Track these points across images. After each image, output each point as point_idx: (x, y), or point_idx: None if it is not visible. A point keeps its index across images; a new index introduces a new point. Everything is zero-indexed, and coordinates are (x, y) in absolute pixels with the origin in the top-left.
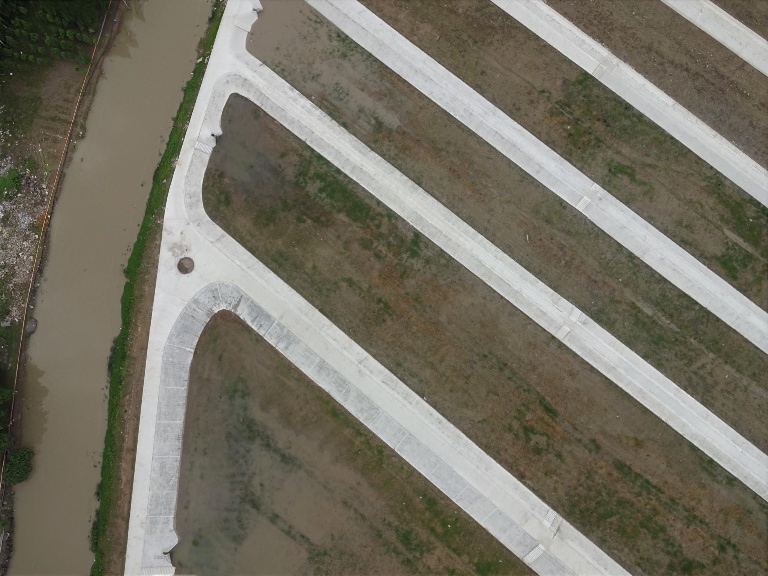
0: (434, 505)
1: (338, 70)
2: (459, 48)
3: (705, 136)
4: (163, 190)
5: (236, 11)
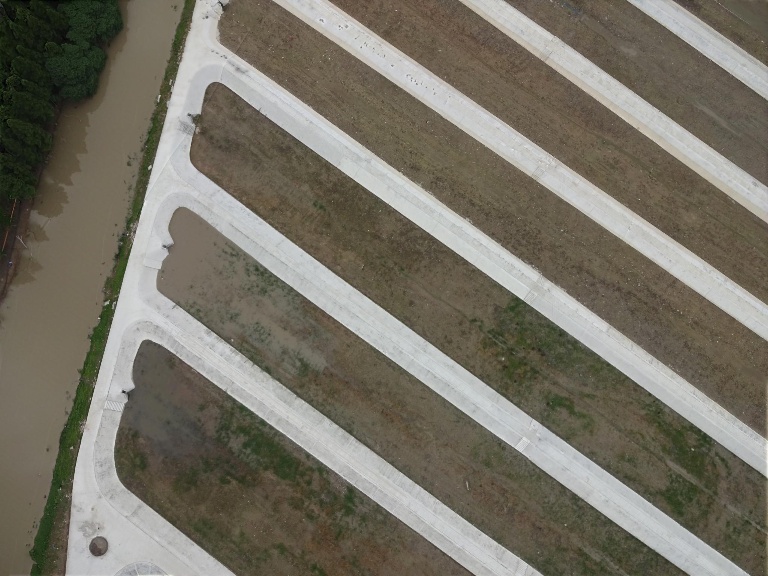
0: None
1: (258, 308)
2: (385, 277)
3: (641, 363)
4: (70, 458)
5: (144, 249)
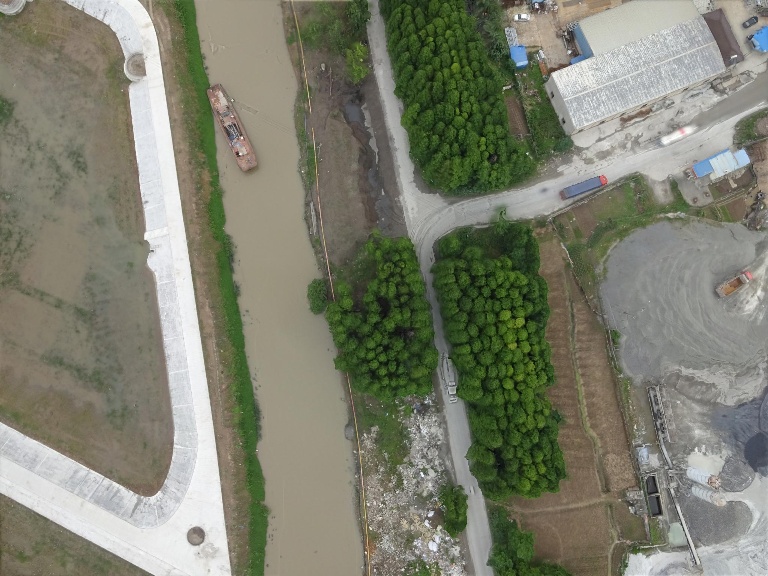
0: None
1: None
2: None
3: None
4: None
5: None
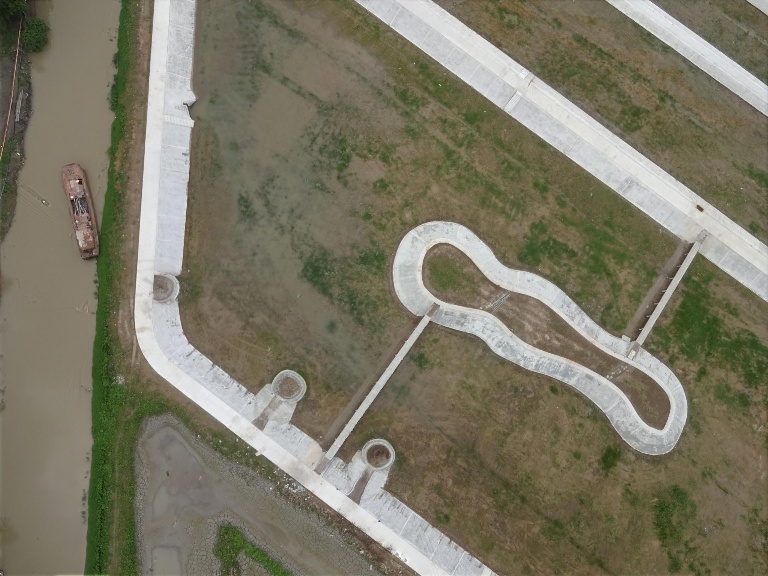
0: (426, 69)
1: None
2: None
3: None
4: None
5: None
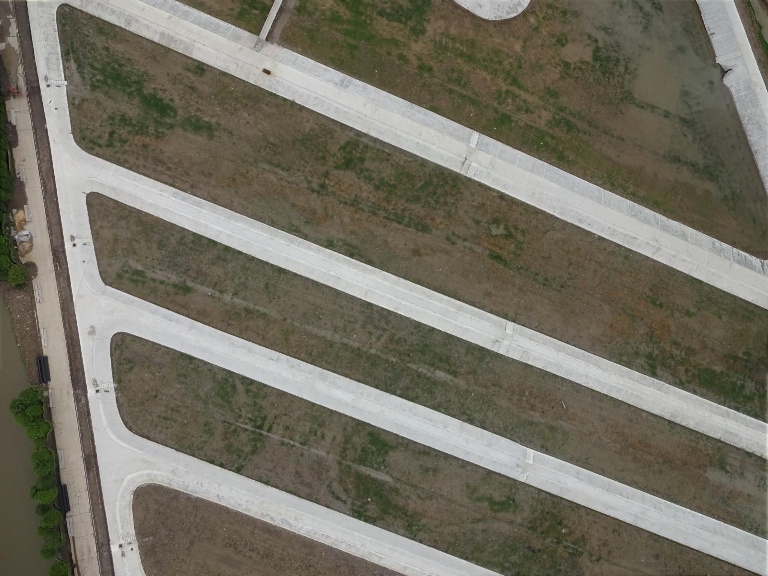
0: (559, 156)
1: None
2: (686, 575)
3: (440, 572)
4: None
5: None
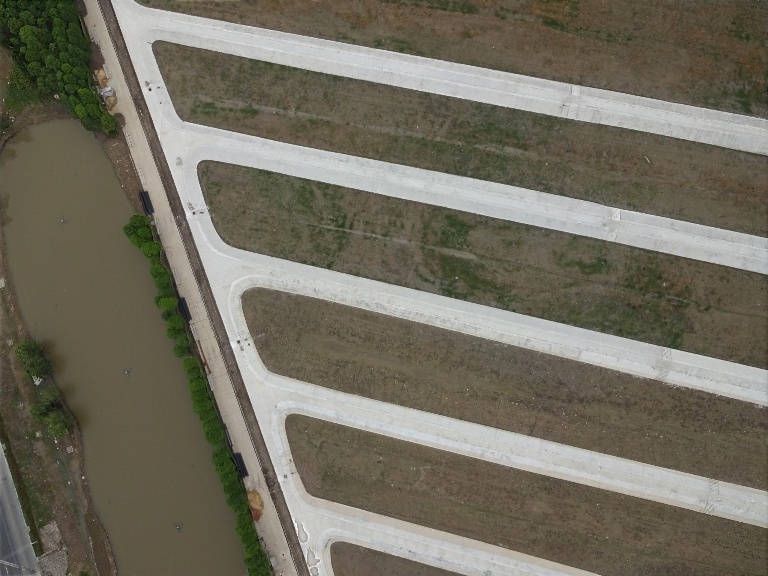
0: None
1: None
2: None
3: (537, 336)
4: None
5: None
